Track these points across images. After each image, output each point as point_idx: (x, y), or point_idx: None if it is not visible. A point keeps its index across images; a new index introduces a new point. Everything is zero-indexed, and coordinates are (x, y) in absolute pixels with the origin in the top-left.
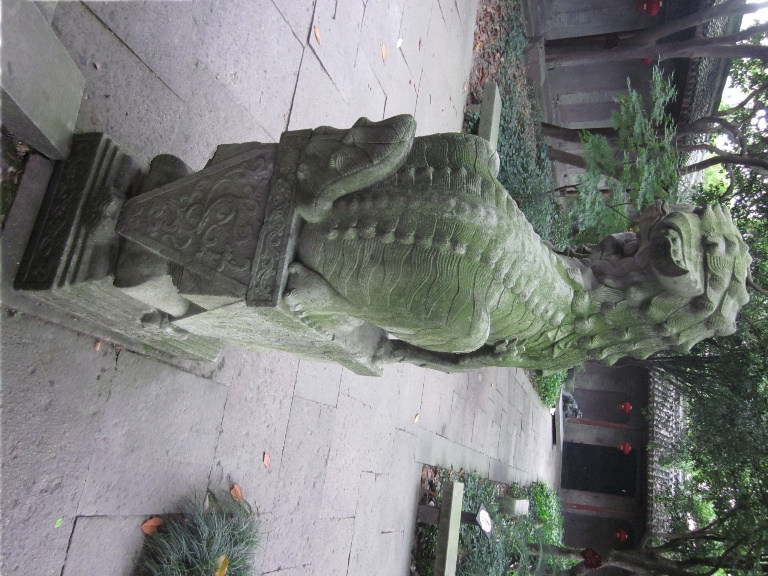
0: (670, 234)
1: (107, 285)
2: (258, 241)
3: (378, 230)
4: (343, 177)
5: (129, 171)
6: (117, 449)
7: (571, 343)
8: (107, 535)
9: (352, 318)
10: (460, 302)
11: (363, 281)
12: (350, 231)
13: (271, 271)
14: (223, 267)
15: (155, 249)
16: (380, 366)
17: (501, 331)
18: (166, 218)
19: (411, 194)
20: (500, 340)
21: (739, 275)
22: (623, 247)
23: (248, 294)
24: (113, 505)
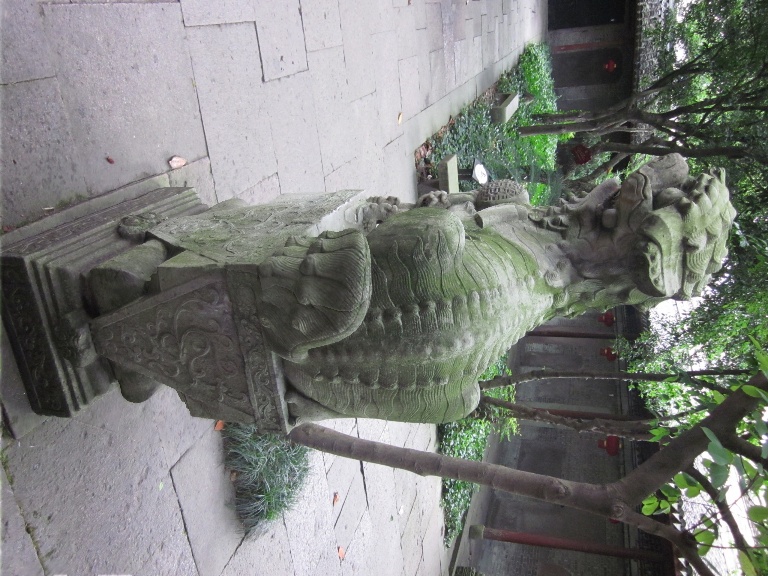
0: (649, 252)
1: (114, 387)
2: (247, 380)
3: (361, 380)
4: (312, 342)
5: (73, 285)
6: (172, 409)
7: None
8: (195, 458)
9: None
10: (451, 412)
11: (359, 412)
12: (334, 381)
13: (271, 406)
14: (223, 398)
15: (148, 376)
16: None
17: None
18: (142, 345)
19: (385, 348)
20: None
21: (718, 254)
22: (602, 218)
23: (257, 424)
24: (189, 440)
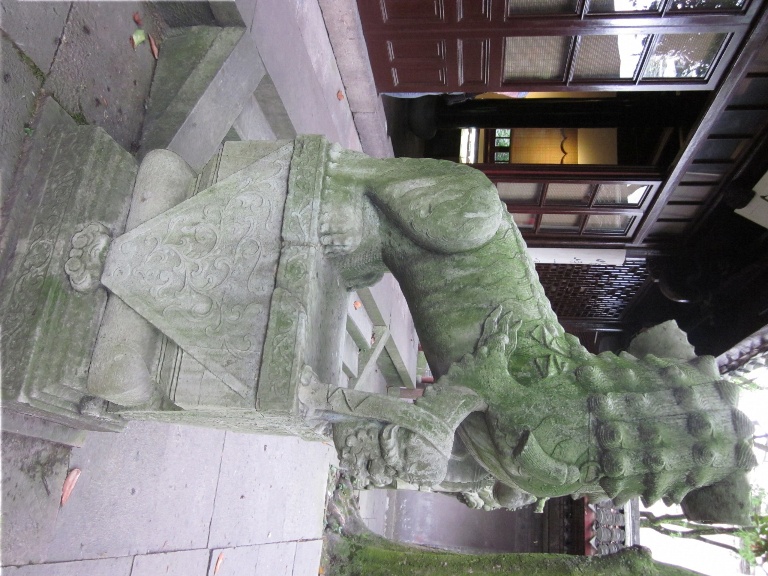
0: None
1: (129, 165)
2: None
3: None
4: None
5: None
6: None
7: (568, 367)
8: None
9: (358, 215)
10: None
11: None
12: None
13: None
14: None
15: None
16: (302, 389)
17: (499, 281)
18: None
19: None
20: (492, 311)
21: None
22: None
23: None
24: None
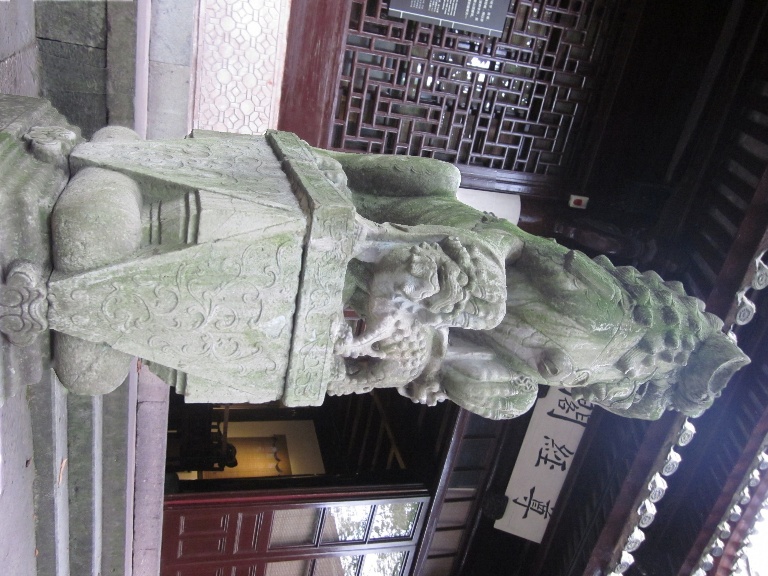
0: None
1: (79, 132)
2: None
3: None
4: None
5: None
6: None
7: None
8: None
9: None
10: None
11: None
12: None
13: None
14: None
15: None
16: None
17: None
18: None
19: None
20: None
21: None
22: None
23: None
24: None
